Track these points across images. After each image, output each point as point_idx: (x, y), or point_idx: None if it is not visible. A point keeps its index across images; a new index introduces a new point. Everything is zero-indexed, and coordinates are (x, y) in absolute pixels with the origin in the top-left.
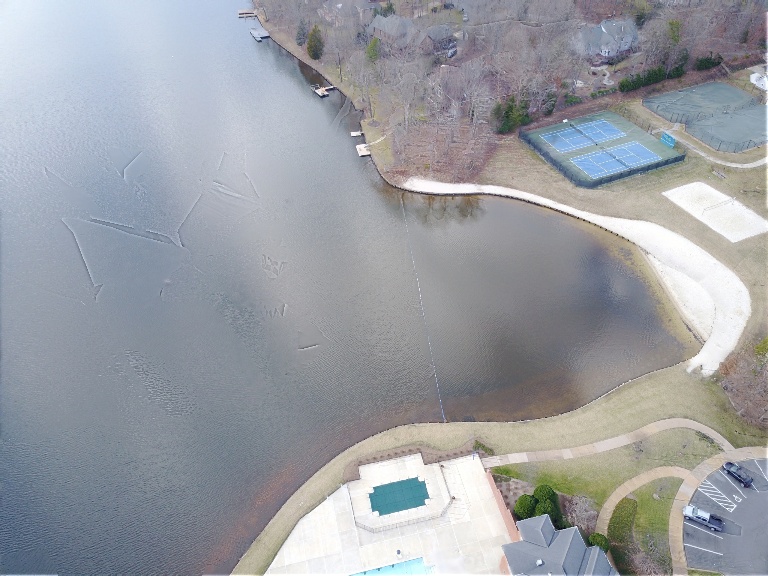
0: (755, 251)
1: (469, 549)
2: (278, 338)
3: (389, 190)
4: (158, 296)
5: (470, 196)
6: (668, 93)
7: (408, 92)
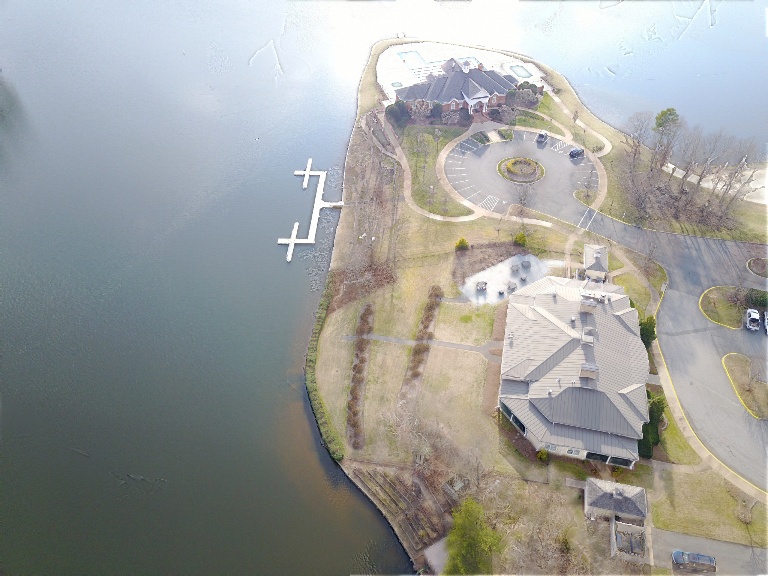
0: None
1: None
2: (608, 58)
3: None
4: (598, 1)
5: None
6: None
7: None
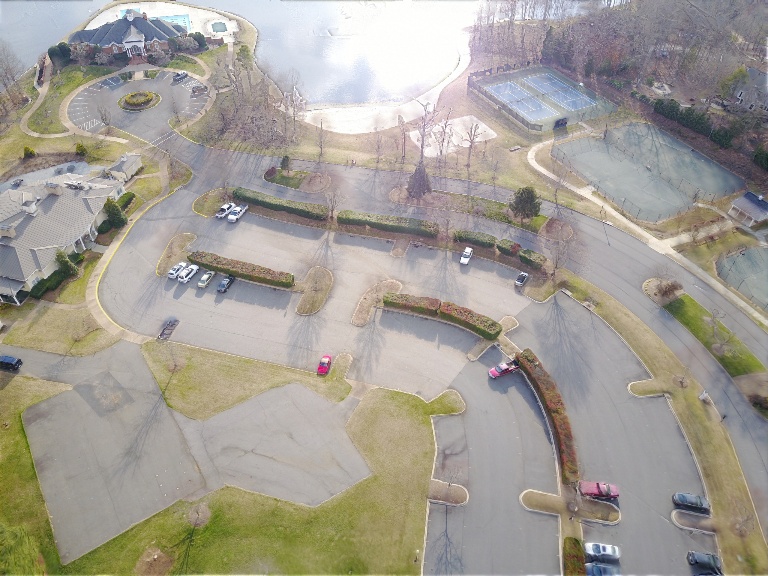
0: None
1: None
2: (331, 22)
3: None
4: None
5: None
6: (681, 142)
7: None
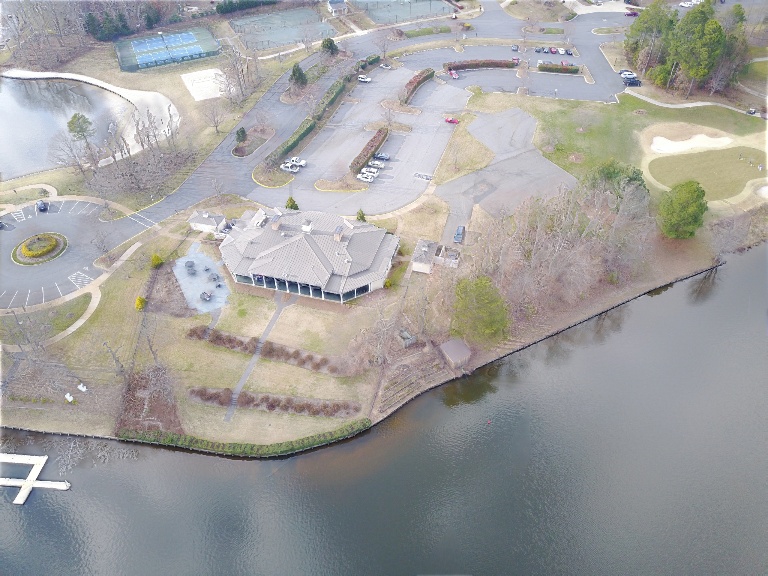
0: (206, 106)
1: None
2: None
3: (4, 81)
4: None
5: (48, 80)
6: (258, 15)
7: (10, 5)
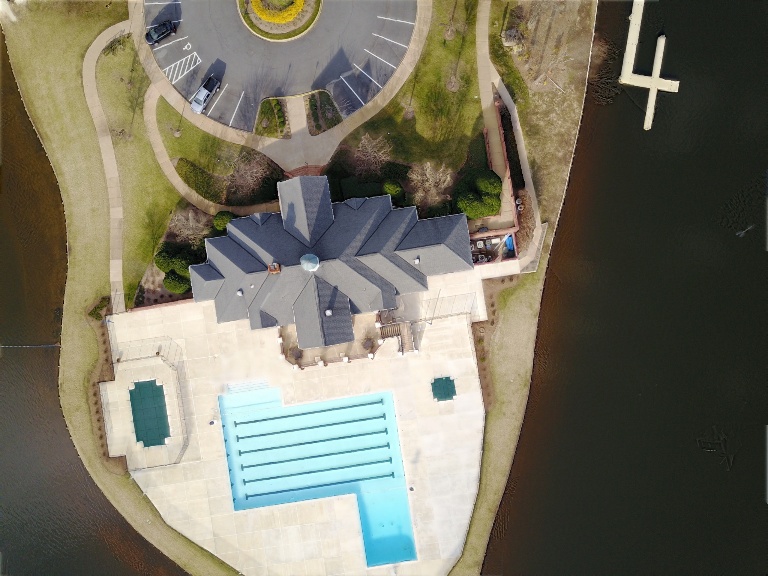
0: None
1: (214, 346)
2: None
3: None
4: None
5: None
6: None
7: None
